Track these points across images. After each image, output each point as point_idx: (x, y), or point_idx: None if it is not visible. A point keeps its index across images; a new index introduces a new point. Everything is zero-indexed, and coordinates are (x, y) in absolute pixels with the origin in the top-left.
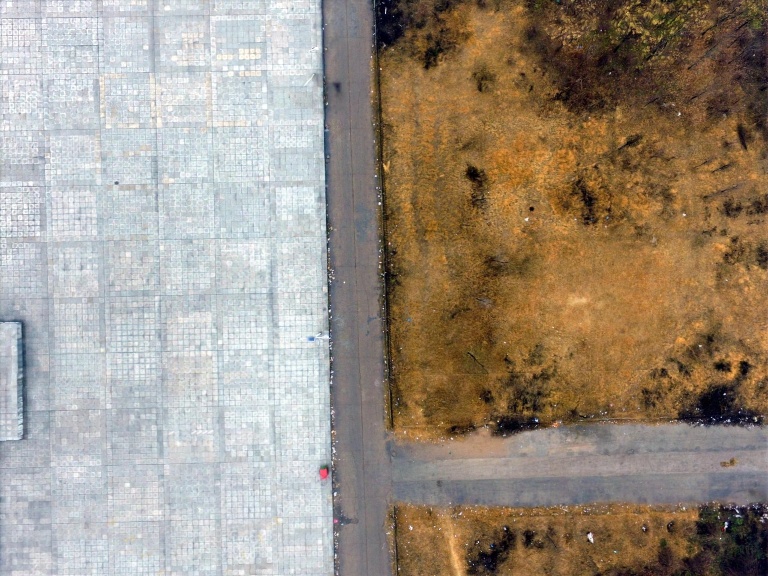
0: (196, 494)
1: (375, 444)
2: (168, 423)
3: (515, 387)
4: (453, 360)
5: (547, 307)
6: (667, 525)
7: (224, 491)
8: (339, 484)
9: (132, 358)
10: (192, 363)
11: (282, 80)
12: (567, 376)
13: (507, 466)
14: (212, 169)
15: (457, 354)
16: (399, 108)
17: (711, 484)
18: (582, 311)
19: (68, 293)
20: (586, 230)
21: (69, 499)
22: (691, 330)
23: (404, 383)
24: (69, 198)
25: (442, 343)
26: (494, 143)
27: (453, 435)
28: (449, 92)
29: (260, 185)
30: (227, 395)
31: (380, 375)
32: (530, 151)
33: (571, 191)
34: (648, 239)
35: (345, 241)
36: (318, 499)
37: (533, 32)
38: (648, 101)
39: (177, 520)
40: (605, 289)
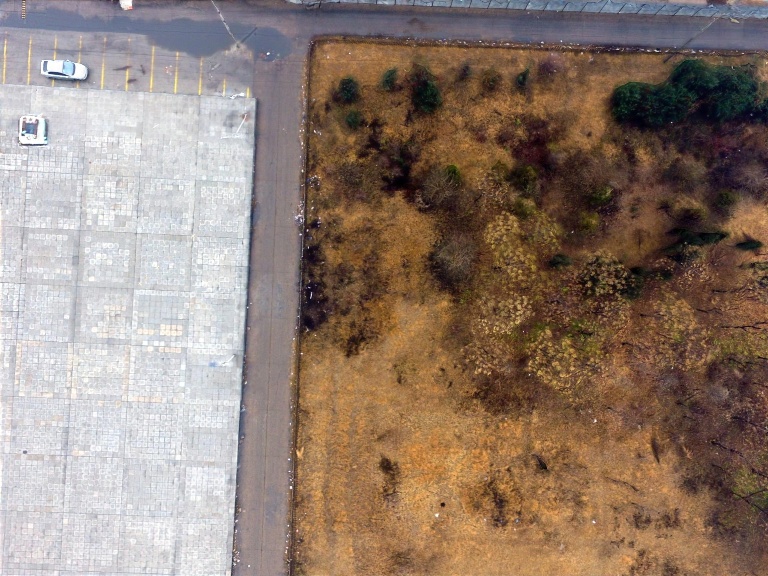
0: None
1: None
2: None
3: None
4: None
5: None
6: None
7: None
8: None
9: None
10: None
11: (202, 358)
12: None
13: None
14: (123, 444)
15: None
16: (317, 395)
17: None
18: None
19: None
20: (495, 532)
21: None
22: None
23: None
24: None
25: None
26: (409, 437)
27: None
28: (368, 382)
29: (171, 463)
30: None
31: None
32: (444, 448)
33: (483, 491)
34: (556, 546)
35: (253, 523)
36: None
37: (455, 330)
38: (565, 406)
39: None
40: None
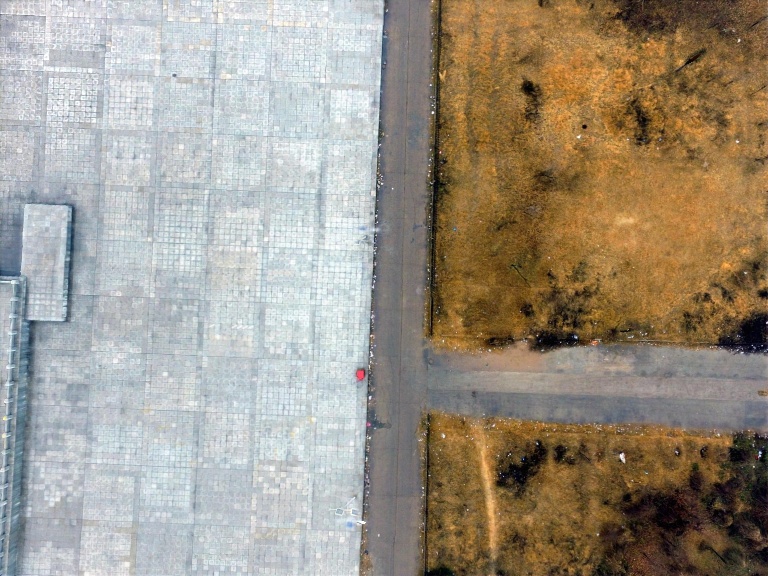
0: (232, 388)
1: (413, 351)
2: (209, 316)
3: (556, 303)
4: (496, 272)
5: (594, 225)
6: (701, 450)
7: (260, 387)
8: (374, 388)
9: (178, 249)
10: (237, 258)
11: None
12: (609, 295)
13: (543, 381)
14: (269, 67)
15: (501, 266)
16: (459, 18)
17: (747, 412)
18: (628, 231)
19: (120, 181)
20: (638, 150)
21: (107, 384)
22: (737, 257)
23: (446, 291)
24: (127, 87)
25: (486, 254)
26: (551, 59)
27: (491, 347)
28: (509, 6)
29: (316, 86)
30: (269, 292)
31: (422, 283)
32: (587, 68)
33: (625, 111)
34: (700, 163)
35: (396, 148)
36: (353, 401)
37: None
38: (708, 26)
39: (212, 412)
40: (653, 211)
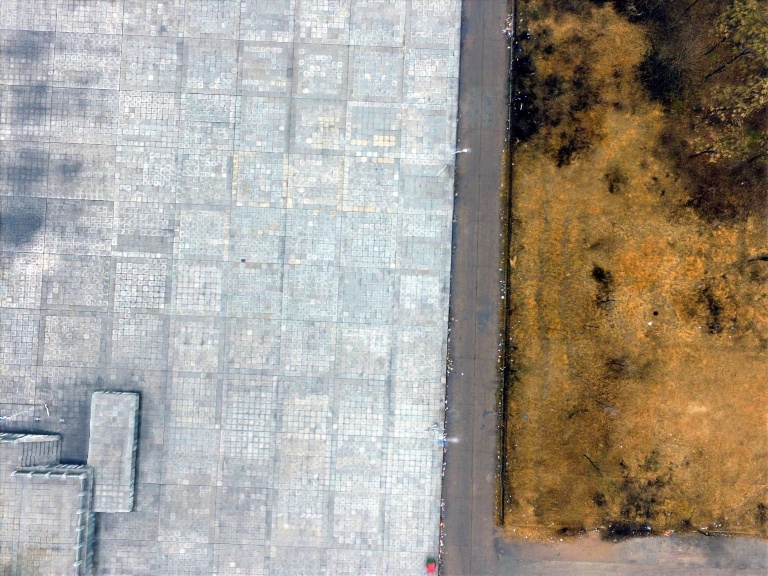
0: None
1: (483, 540)
2: (278, 504)
3: (629, 493)
4: (568, 461)
5: (666, 414)
6: None
7: None
8: None
9: (246, 436)
10: (306, 445)
11: (414, 169)
12: (683, 485)
13: (616, 572)
14: (339, 253)
15: (572, 455)
16: (529, 204)
17: None
18: (701, 420)
19: (187, 367)
20: (710, 339)
21: (174, 575)
22: None
23: (517, 481)
24: (195, 272)
25: (558, 443)
26: (622, 245)
27: (563, 536)
28: (580, 191)
29: (385, 272)
30: (338, 480)
31: (493, 470)
32: (658, 256)
33: (697, 299)
34: None
35: (466, 333)
36: None
37: (668, 138)
38: None
39: None
40: (726, 400)
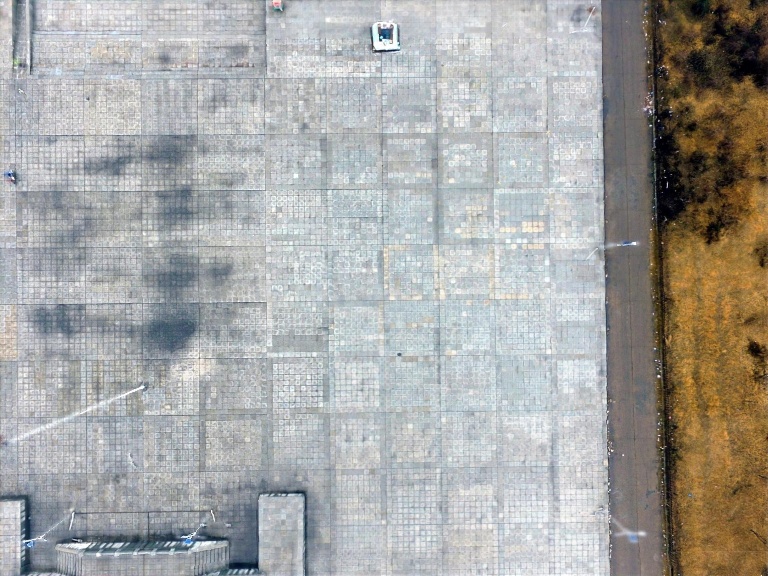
0: None
1: None
2: None
3: None
4: (734, 536)
5: None
6: None
7: None
8: None
9: (413, 530)
10: (473, 536)
11: (565, 253)
12: None
13: None
14: (494, 341)
15: (738, 530)
16: (681, 282)
17: None
18: None
19: (350, 464)
20: None
21: None
22: None
23: (685, 559)
24: (352, 369)
25: (724, 519)
26: None
27: None
28: (730, 267)
29: (542, 358)
30: (507, 569)
31: (659, 549)
32: None
33: None
34: None
35: (624, 413)
36: None
37: None
38: None
39: None
40: None
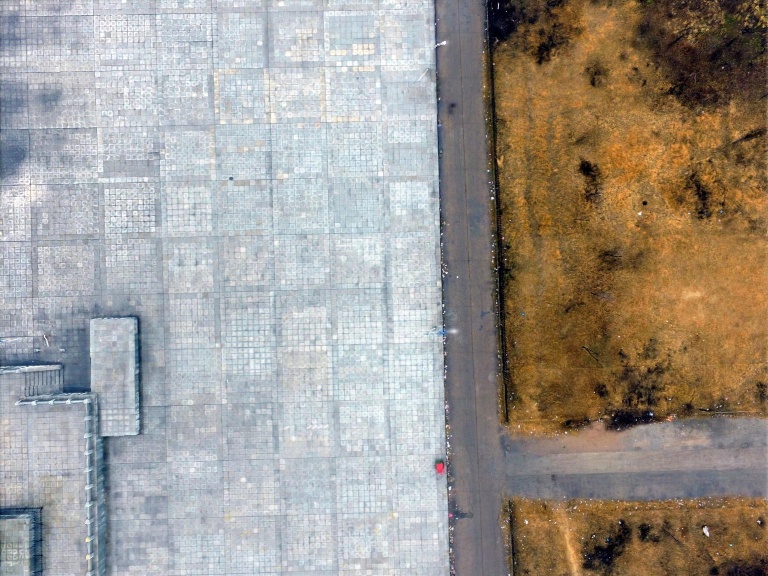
0: (312, 489)
1: (489, 438)
2: (283, 418)
3: (630, 381)
4: (567, 354)
5: (661, 301)
6: None
7: (340, 486)
8: (453, 478)
9: (247, 353)
10: (307, 358)
11: (396, 75)
12: (682, 370)
13: (621, 460)
14: (326, 164)
15: (571, 348)
16: (512, 103)
17: None
18: (696, 305)
19: (183, 288)
20: (700, 224)
21: (185, 494)
22: None
23: (519, 377)
24: (184, 194)
25: (556, 337)
26: (607, 137)
27: (567, 429)
28: (562, 87)
29: (374, 180)
30: (342, 390)
31: (494, 369)
32: (644, 145)
33: (685, 185)
34: (762, 233)
35: (458, 236)
36: (433, 493)
37: (647, 27)
38: (761, 95)
39: (293, 515)
40: (719, 283)
